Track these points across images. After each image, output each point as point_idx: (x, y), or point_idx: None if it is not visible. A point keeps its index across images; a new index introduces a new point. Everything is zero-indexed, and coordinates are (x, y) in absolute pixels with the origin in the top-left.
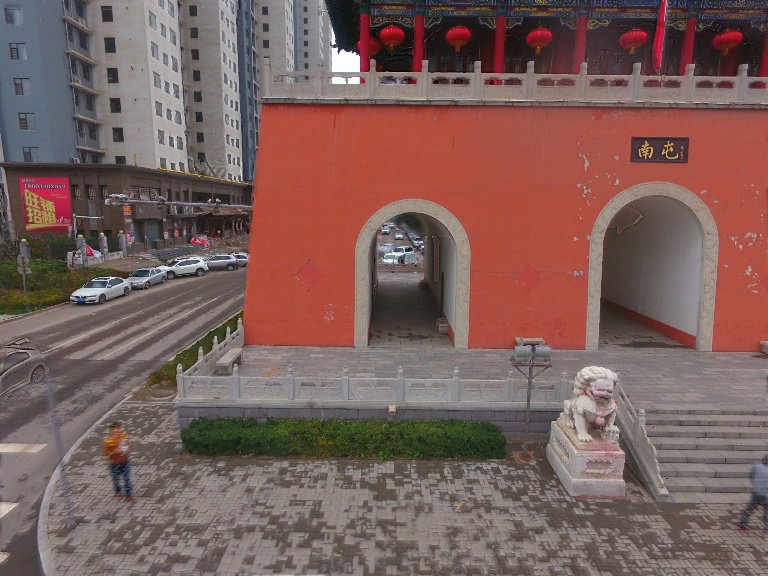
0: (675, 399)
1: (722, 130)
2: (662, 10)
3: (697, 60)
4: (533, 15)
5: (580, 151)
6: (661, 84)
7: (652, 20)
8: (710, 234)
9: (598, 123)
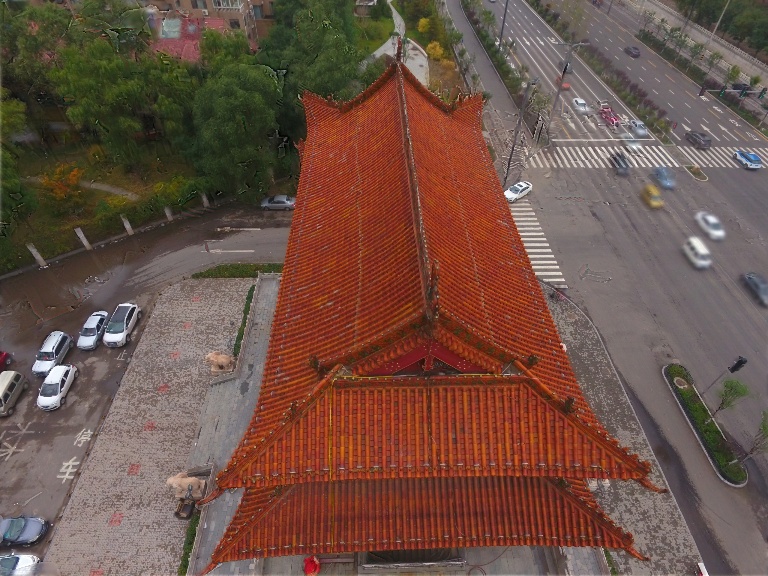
0: None
1: None
2: None
3: None
4: None
5: None
6: None
7: None
8: None
9: None
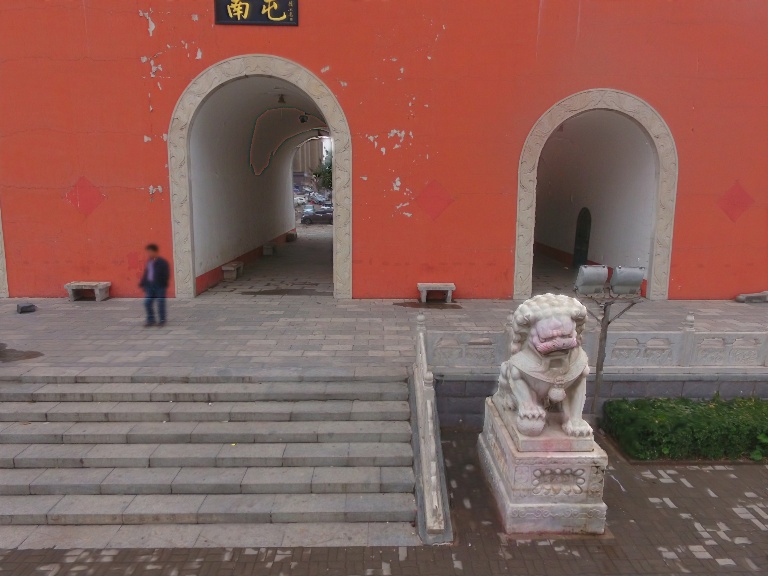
0: (101, 360)
1: None
2: None
3: None
4: None
5: (140, 7)
6: None
7: None
8: (338, 132)
9: None
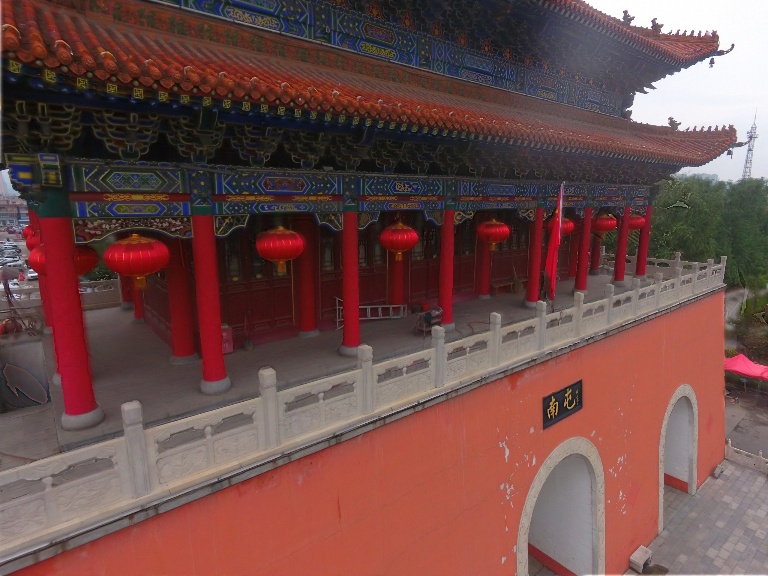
0: None
1: (601, 360)
2: (557, 231)
3: (514, 227)
4: (393, 208)
5: (500, 439)
6: (559, 322)
7: (510, 210)
8: (599, 476)
9: (514, 393)
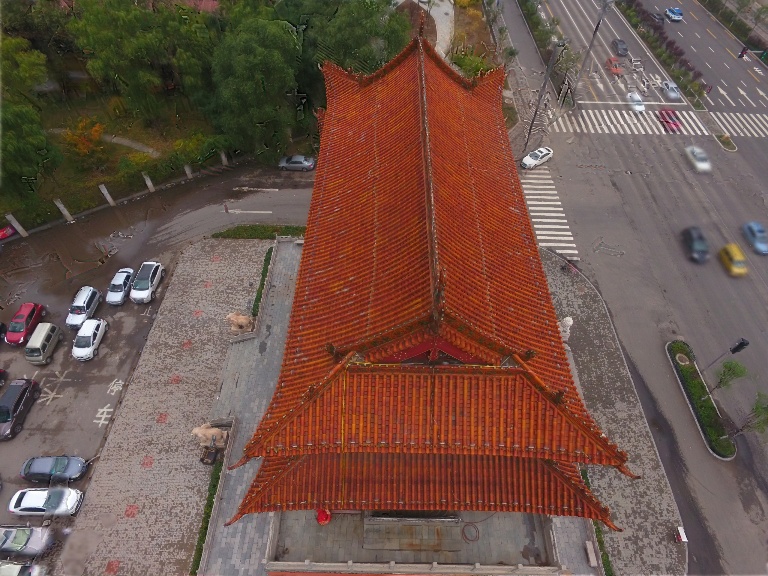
0: None
1: None
2: None
3: None
4: None
5: None
6: None
7: None
8: None
9: None
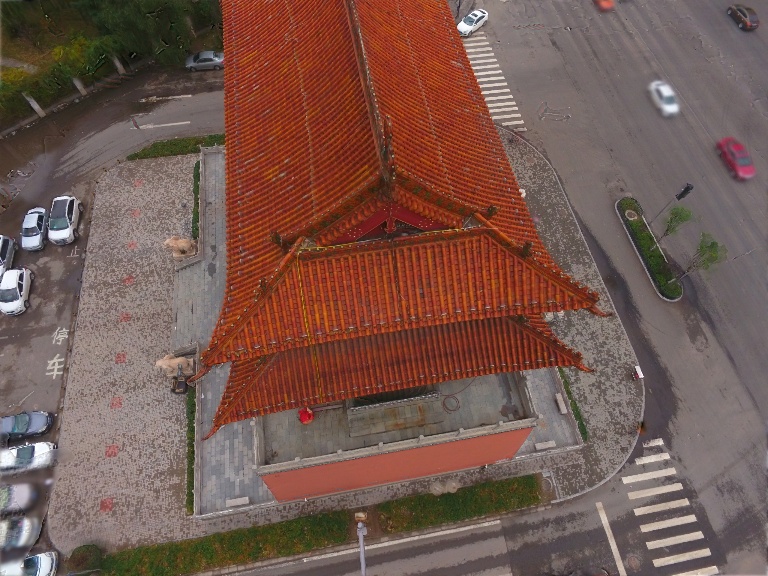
0: None
1: None
2: None
3: None
4: None
5: None
6: None
7: None
8: None
9: None
